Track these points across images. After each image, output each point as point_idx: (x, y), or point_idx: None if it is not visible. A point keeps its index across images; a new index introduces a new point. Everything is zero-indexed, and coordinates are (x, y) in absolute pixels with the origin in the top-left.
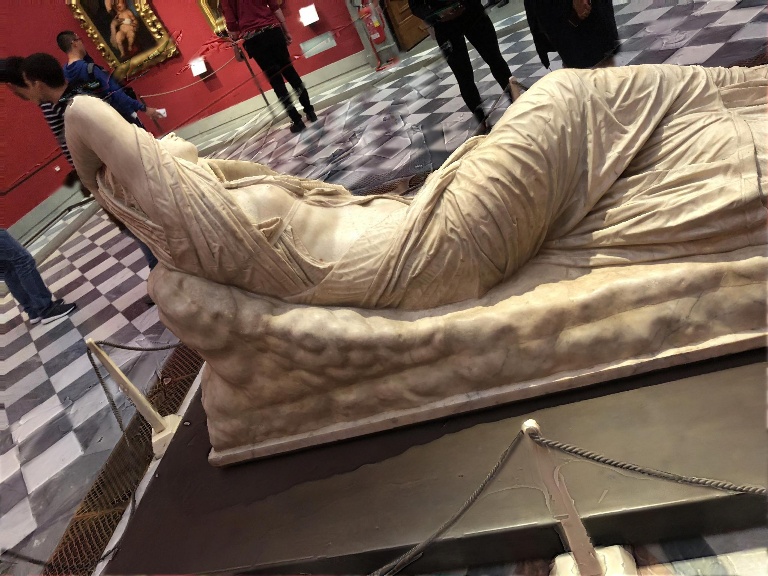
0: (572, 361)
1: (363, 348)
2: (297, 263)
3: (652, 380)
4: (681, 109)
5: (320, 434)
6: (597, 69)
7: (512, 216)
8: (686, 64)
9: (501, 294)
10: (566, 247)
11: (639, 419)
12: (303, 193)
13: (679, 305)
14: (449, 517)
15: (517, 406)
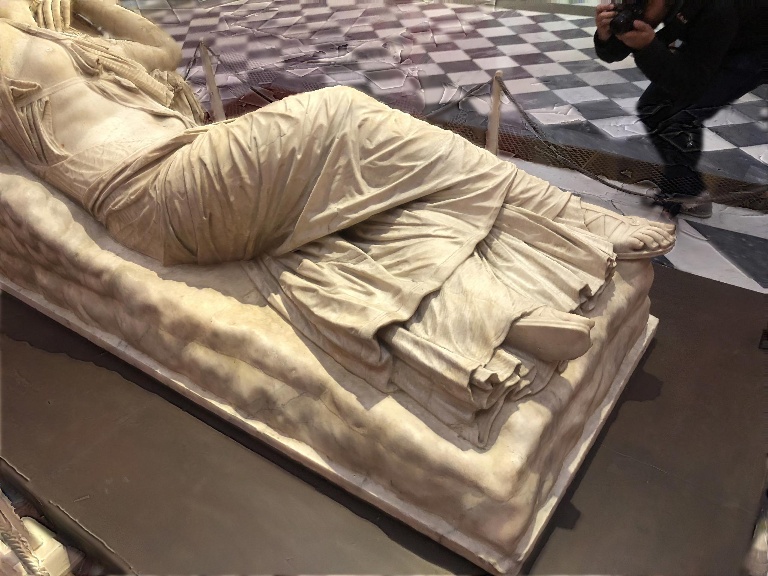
0: (192, 373)
1: (47, 245)
2: (38, 136)
3: (239, 437)
4: (438, 203)
5: (24, 294)
6: (389, 110)
7: (205, 208)
8: (766, 162)
9: (181, 274)
10: (269, 269)
11: (190, 461)
12: (95, 74)
13: (283, 389)
14: (0, 427)
15: (148, 379)
